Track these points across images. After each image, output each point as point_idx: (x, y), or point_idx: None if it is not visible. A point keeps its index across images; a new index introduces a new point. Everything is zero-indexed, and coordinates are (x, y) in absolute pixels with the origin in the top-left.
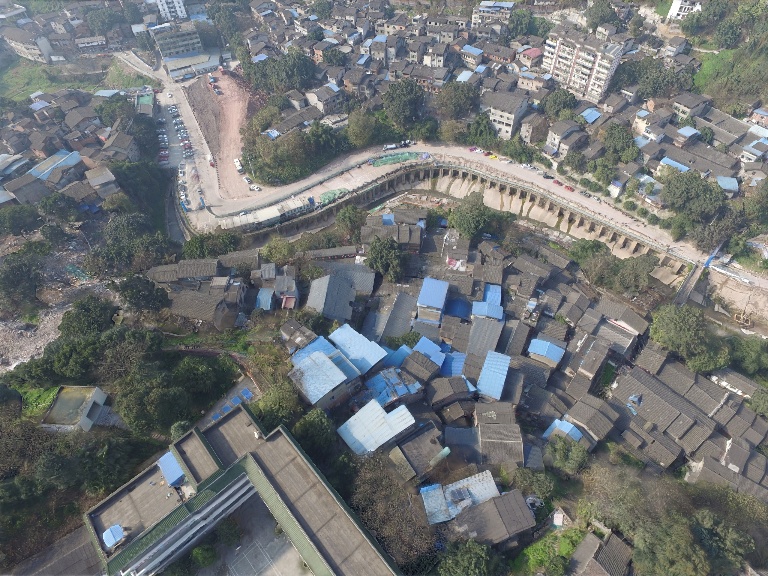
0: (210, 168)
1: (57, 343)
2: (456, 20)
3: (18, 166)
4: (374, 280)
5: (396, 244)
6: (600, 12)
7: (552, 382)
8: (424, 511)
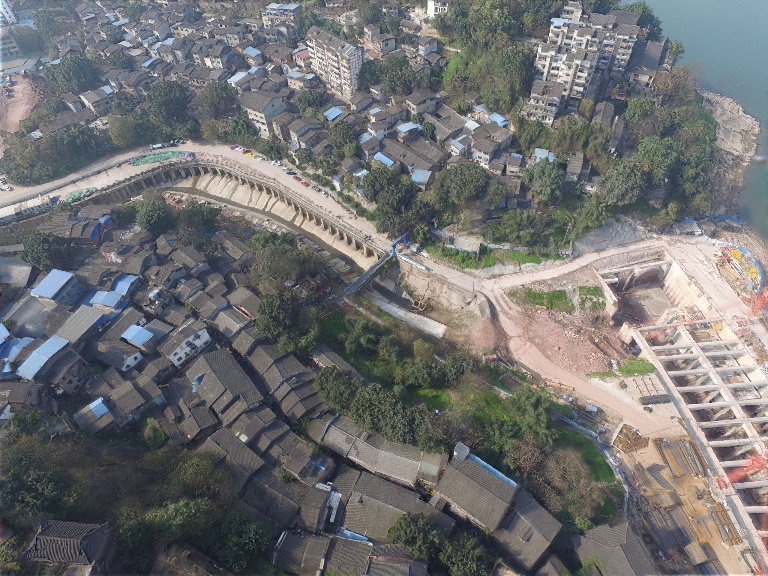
0: None
1: None
2: (248, 22)
3: None
4: (31, 273)
5: (50, 238)
6: (363, 13)
7: (141, 364)
8: None
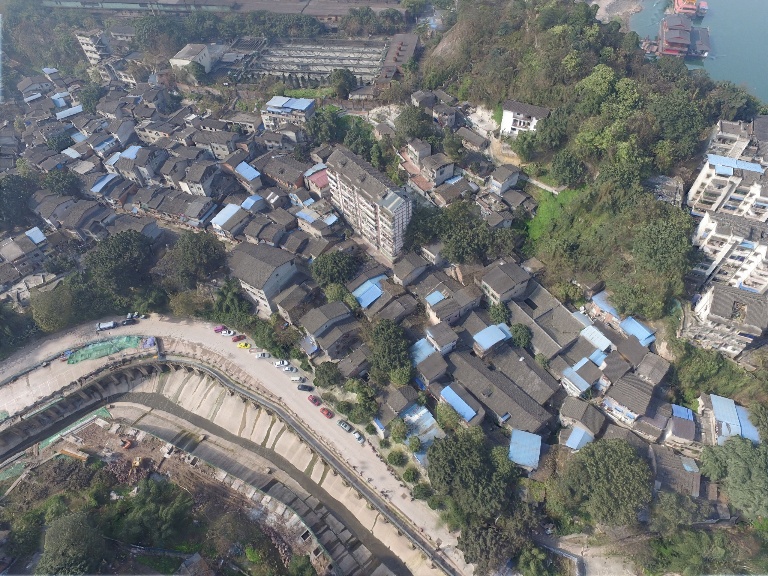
0: None
1: None
2: (242, 121)
3: None
4: None
5: None
6: (407, 125)
7: None
8: None
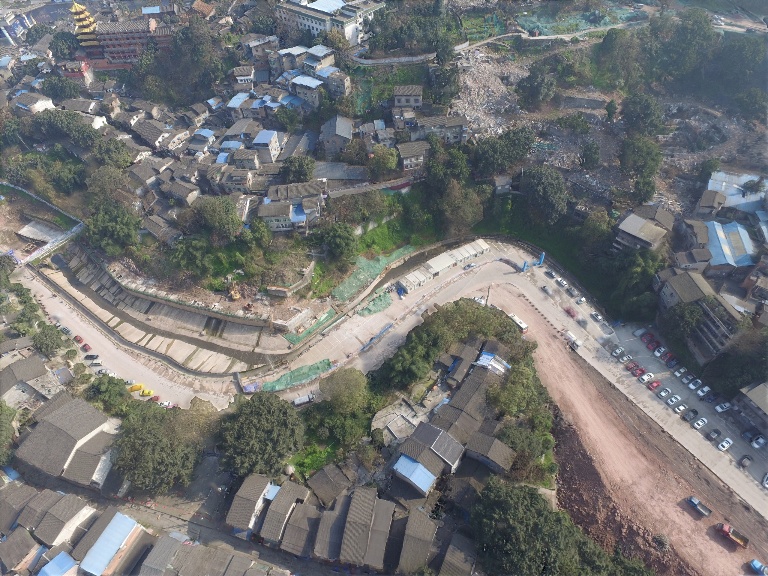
0: None
1: None
2: None
3: (764, 231)
4: None
5: (288, 163)
6: None
7: None
8: None
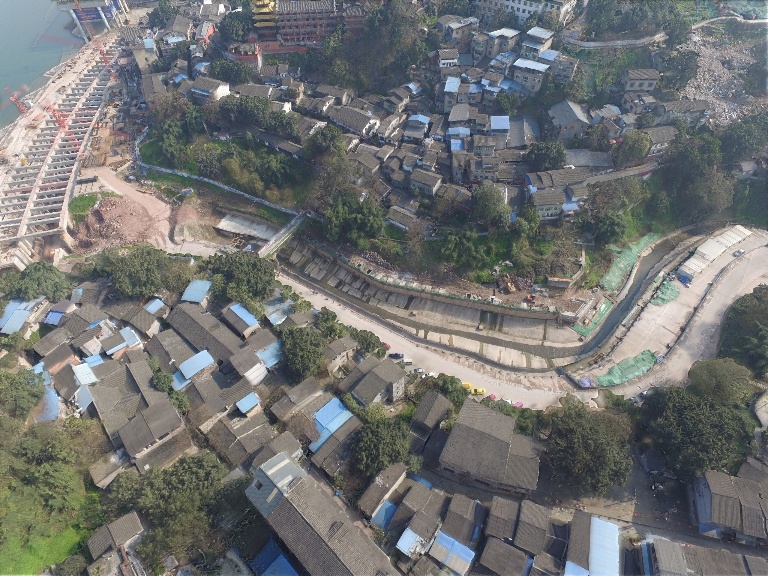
0: None
1: (665, 1)
2: None
3: None
4: None
5: (544, 150)
6: None
7: None
8: None
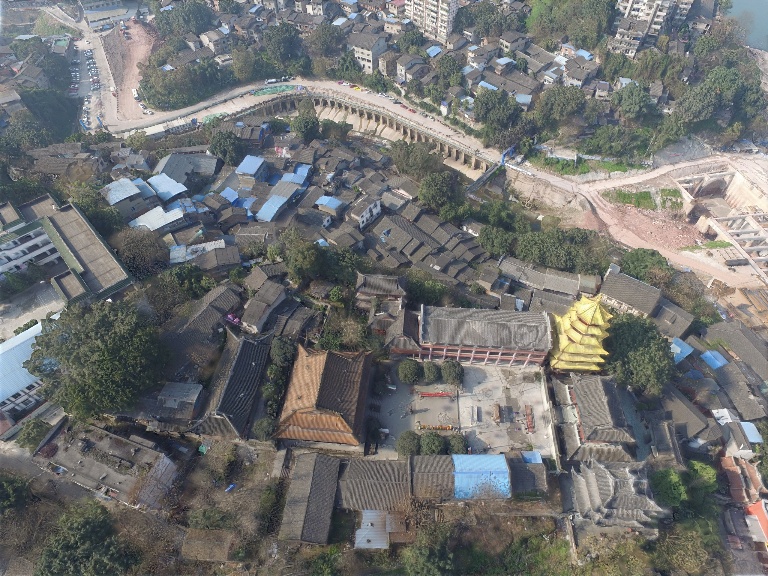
0: (113, 98)
1: None
2: None
3: None
4: (216, 164)
5: (233, 135)
6: None
7: (332, 226)
8: (169, 257)
